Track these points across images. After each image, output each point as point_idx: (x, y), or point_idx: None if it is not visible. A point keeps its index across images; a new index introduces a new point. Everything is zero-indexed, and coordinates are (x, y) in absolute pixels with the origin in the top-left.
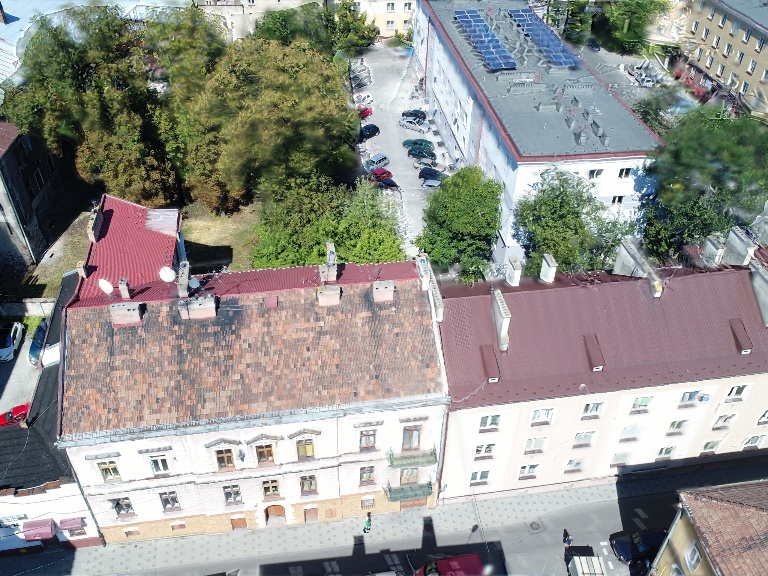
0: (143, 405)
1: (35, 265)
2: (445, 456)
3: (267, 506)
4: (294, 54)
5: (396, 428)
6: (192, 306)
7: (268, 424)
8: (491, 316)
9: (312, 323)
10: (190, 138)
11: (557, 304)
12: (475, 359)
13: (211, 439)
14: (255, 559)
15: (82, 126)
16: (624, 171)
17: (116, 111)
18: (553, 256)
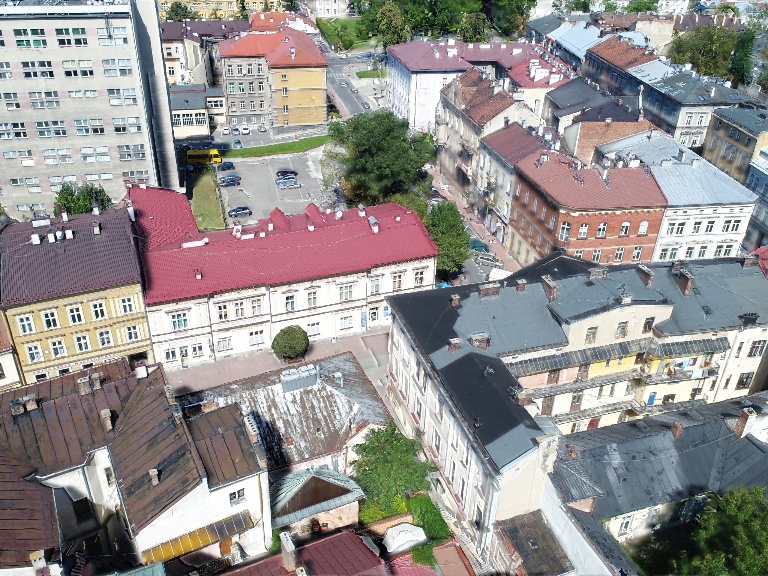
0: None
1: None
2: None
3: None
4: None
5: None
6: None
7: None
8: None
9: None
10: None
11: None
12: None
13: None
14: None
15: None
16: None
17: None
18: None
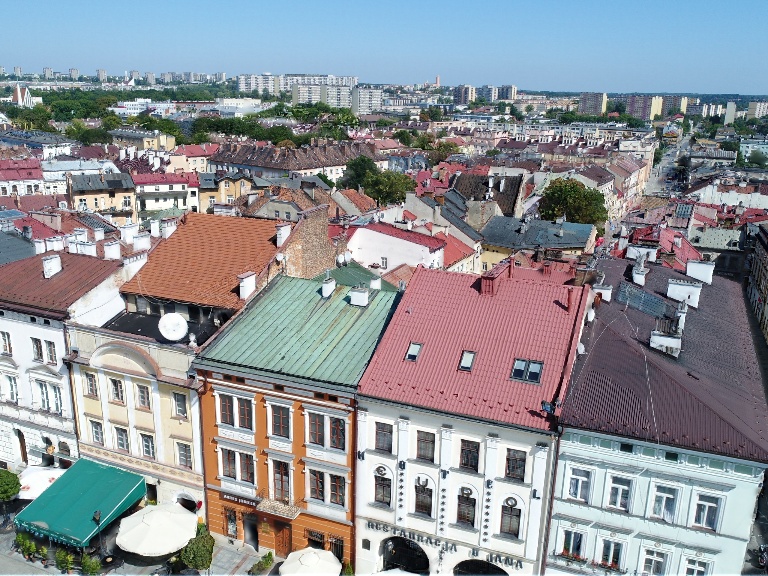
0: None
1: None
2: None
3: None
4: None
5: None
6: None
7: None
8: None
9: None
10: None
11: None
12: None
13: None
14: None
15: None
16: None
17: None
18: None
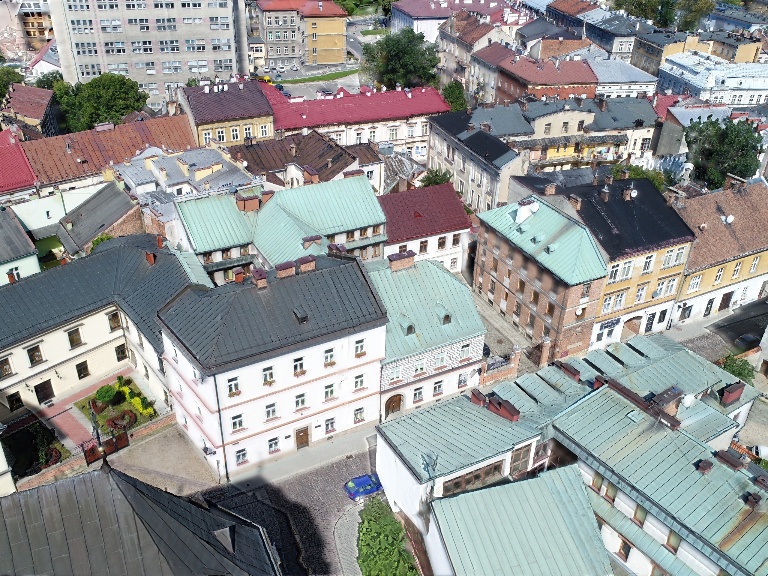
0: None
1: None
2: None
3: None
4: None
5: None
6: None
7: None
8: None
9: None
10: None
11: None
12: None
13: None
14: None
15: None
16: None
17: None
18: None
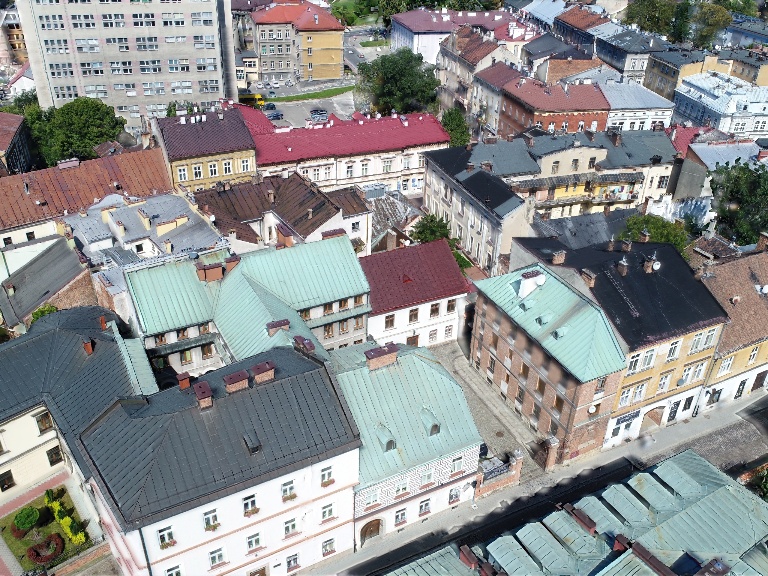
0: None
1: None
2: None
3: None
4: (718, 6)
5: None
6: None
7: None
8: None
9: None
10: None
11: None
12: None
13: None
14: None
15: None
16: None
17: None
18: None
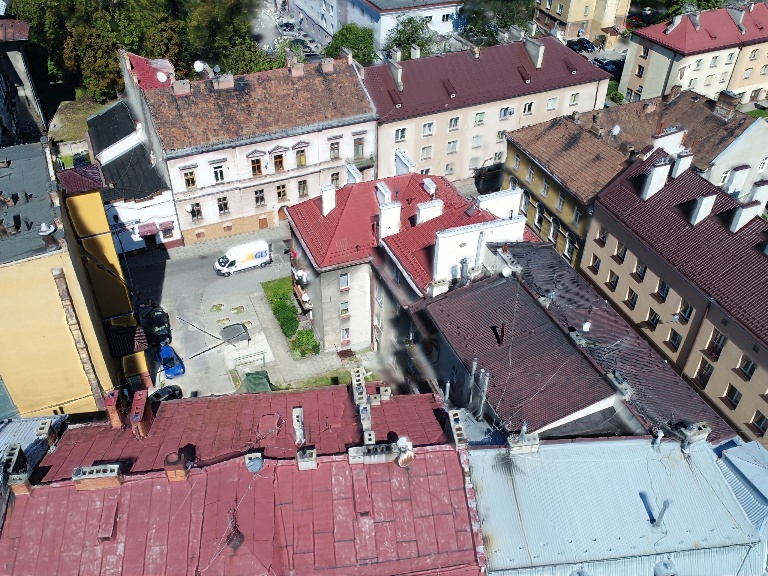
0: (207, 133)
1: (46, 132)
2: (378, 163)
3: (280, 207)
4: None
5: (350, 140)
6: (221, 79)
7: (282, 135)
8: (390, 75)
9: (291, 86)
10: (146, 28)
11: (425, 66)
12: (386, 97)
13: (249, 151)
14: (279, 239)
15: (65, 25)
16: (445, 17)
17: (93, 9)
18: (417, 45)
